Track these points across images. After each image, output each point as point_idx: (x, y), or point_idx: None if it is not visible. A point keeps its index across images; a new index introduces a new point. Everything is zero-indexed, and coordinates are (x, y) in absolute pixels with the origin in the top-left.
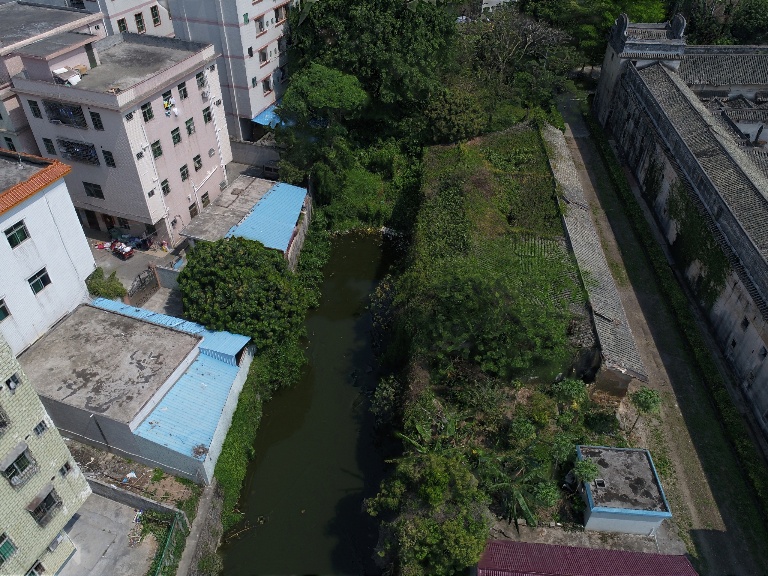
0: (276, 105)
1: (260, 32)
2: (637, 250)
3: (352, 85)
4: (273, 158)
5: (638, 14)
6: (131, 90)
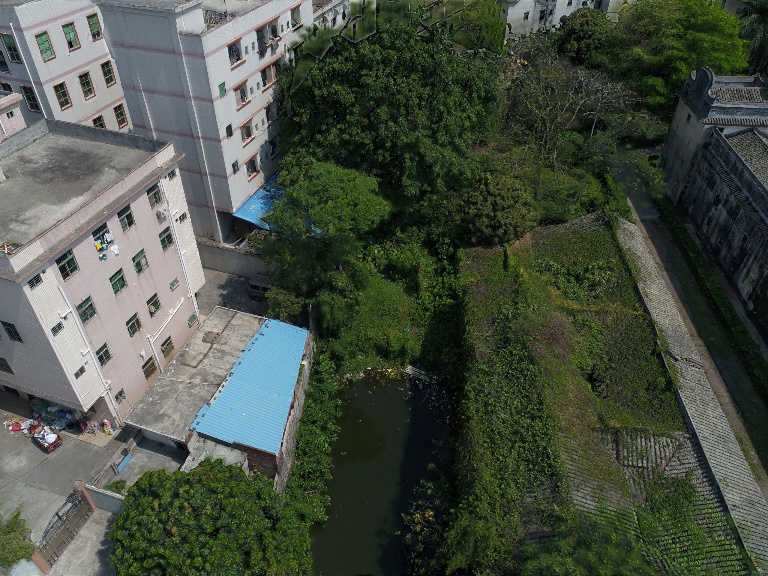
0: (265, 189)
1: (242, 103)
2: (762, 412)
3: (369, 193)
4: (261, 268)
5: (717, 63)
6: (36, 242)
